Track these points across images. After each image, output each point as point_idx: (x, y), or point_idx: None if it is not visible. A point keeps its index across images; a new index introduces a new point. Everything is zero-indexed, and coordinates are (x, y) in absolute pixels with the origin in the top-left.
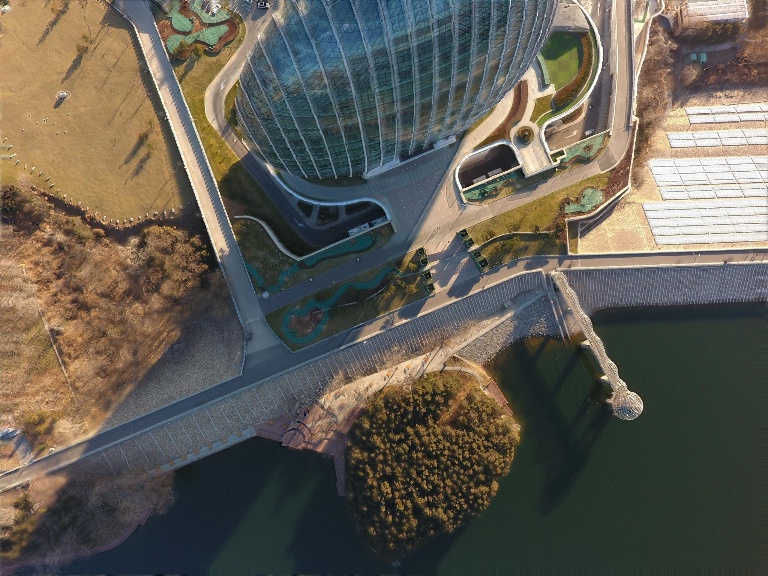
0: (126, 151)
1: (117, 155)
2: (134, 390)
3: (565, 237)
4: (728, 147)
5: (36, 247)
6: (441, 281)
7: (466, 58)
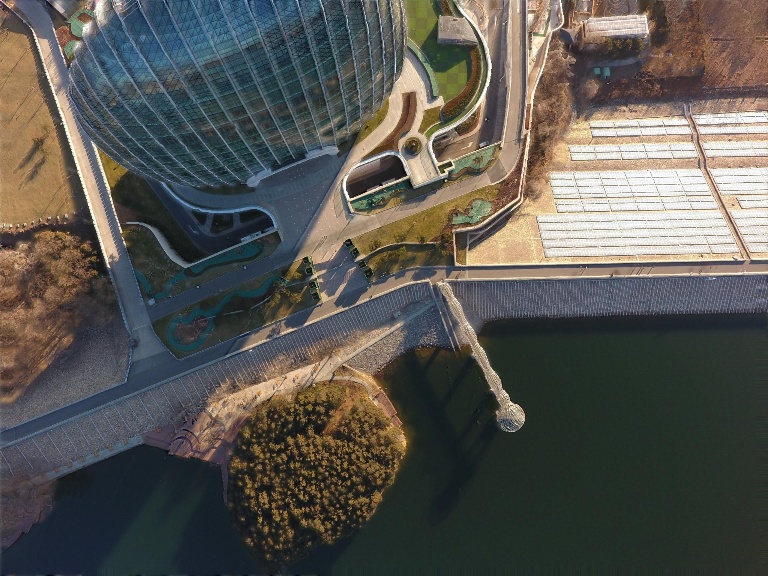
0: (21, 156)
1: (12, 159)
2: (21, 396)
3: (452, 248)
4: (628, 161)
5: None
6: (329, 290)
7: (291, 70)
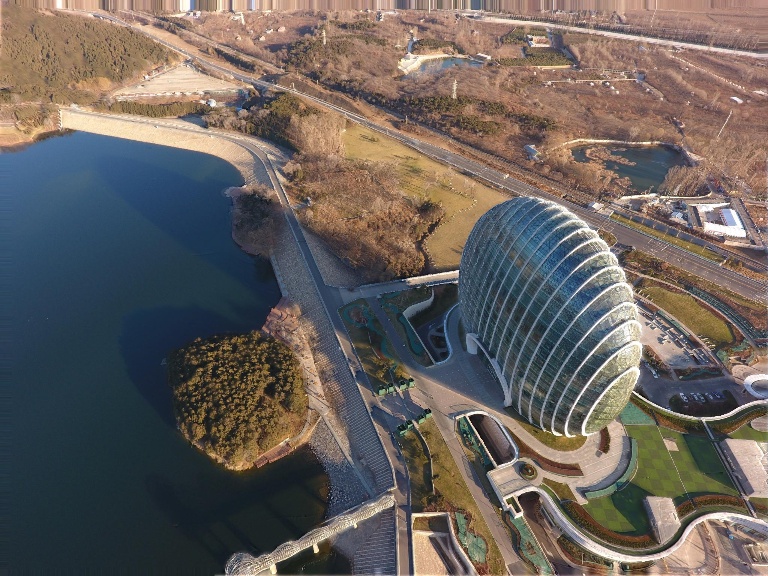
0: None
1: None
2: (323, 246)
3: (430, 510)
4: None
5: (409, 215)
6: (386, 402)
7: None
